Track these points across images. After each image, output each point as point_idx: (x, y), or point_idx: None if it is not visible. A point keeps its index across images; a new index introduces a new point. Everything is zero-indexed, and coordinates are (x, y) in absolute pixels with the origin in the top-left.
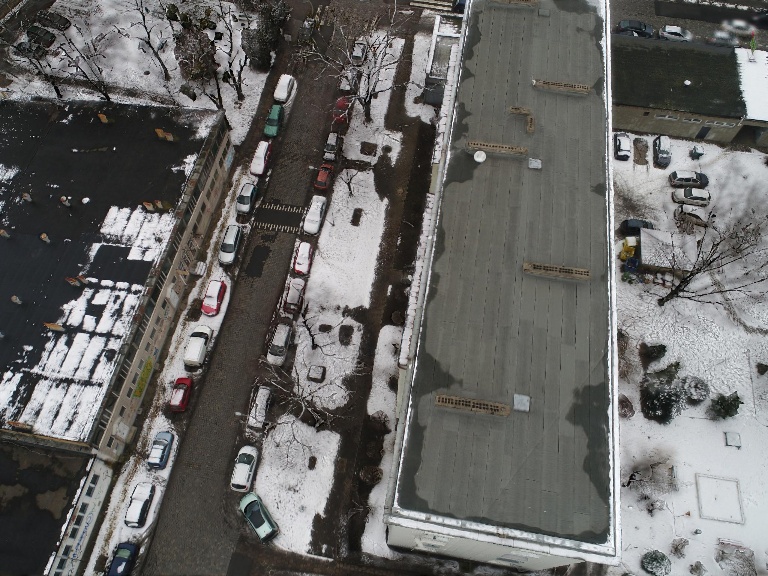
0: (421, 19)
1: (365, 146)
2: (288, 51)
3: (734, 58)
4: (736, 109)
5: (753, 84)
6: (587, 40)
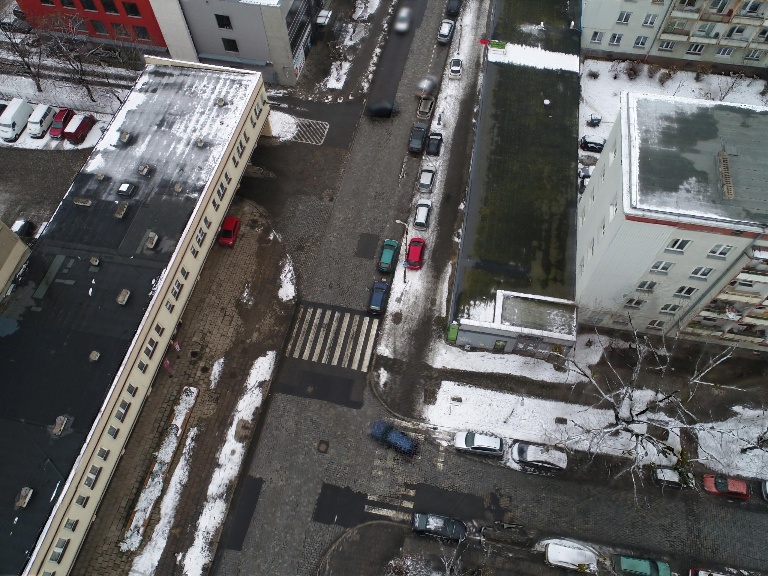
0: (399, 358)
1: (654, 435)
2: (479, 559)
3: (502, 64)
4: (569, 77)
5: (535, 59)
6: (759, 121)
